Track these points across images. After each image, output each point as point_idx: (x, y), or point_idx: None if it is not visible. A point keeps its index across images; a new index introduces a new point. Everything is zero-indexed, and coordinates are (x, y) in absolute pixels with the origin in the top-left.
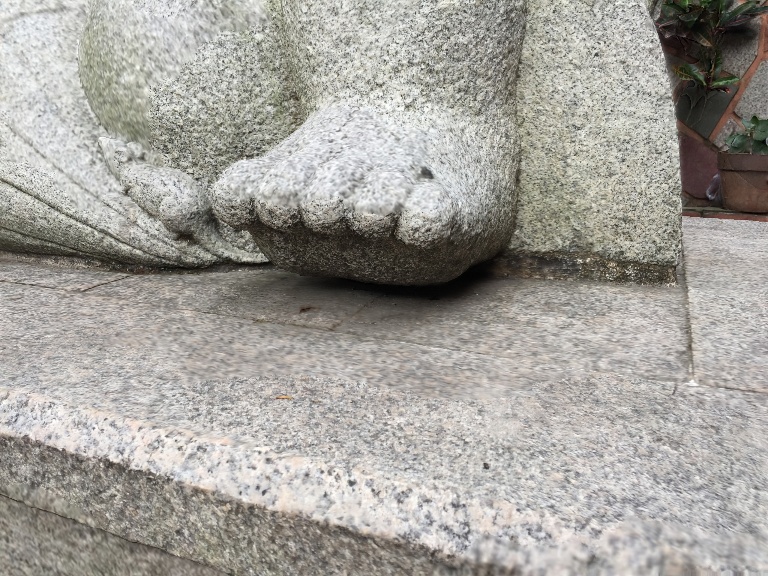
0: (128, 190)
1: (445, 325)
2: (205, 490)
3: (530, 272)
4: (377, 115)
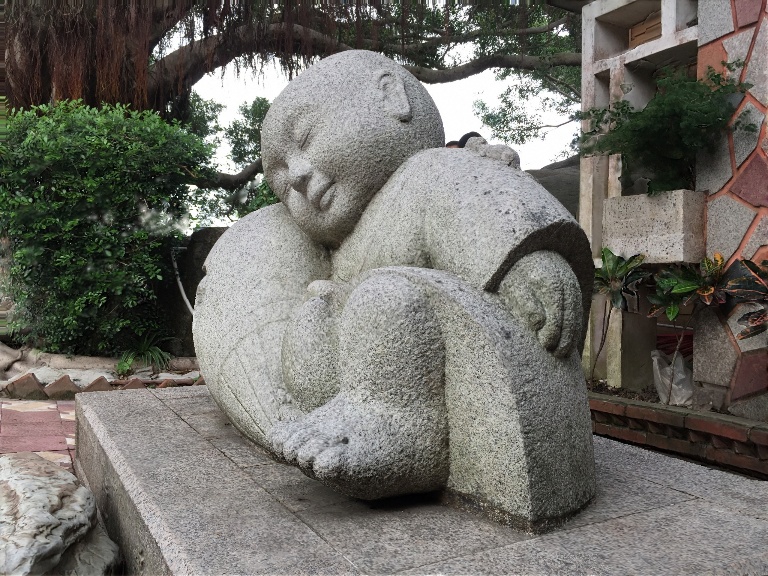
0: (280, 418)
1: (343, 523)
2: (164, 557)
3: (459, 504)
4: (347, 404)
